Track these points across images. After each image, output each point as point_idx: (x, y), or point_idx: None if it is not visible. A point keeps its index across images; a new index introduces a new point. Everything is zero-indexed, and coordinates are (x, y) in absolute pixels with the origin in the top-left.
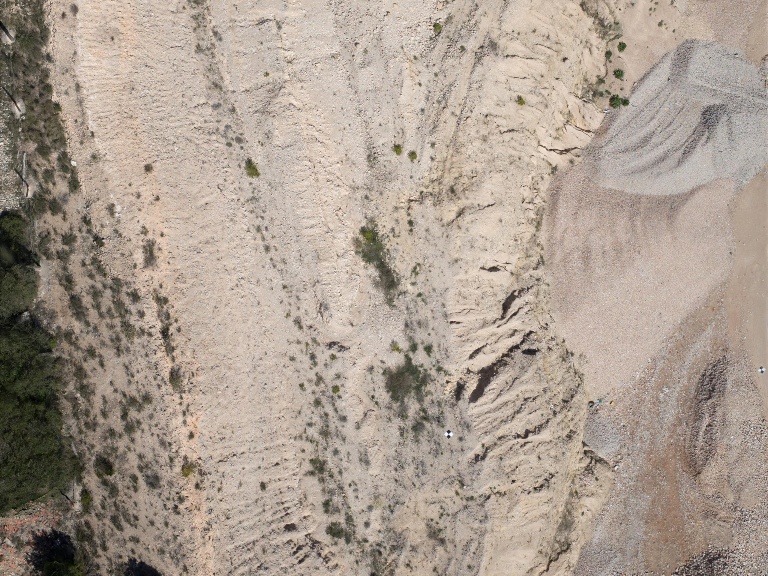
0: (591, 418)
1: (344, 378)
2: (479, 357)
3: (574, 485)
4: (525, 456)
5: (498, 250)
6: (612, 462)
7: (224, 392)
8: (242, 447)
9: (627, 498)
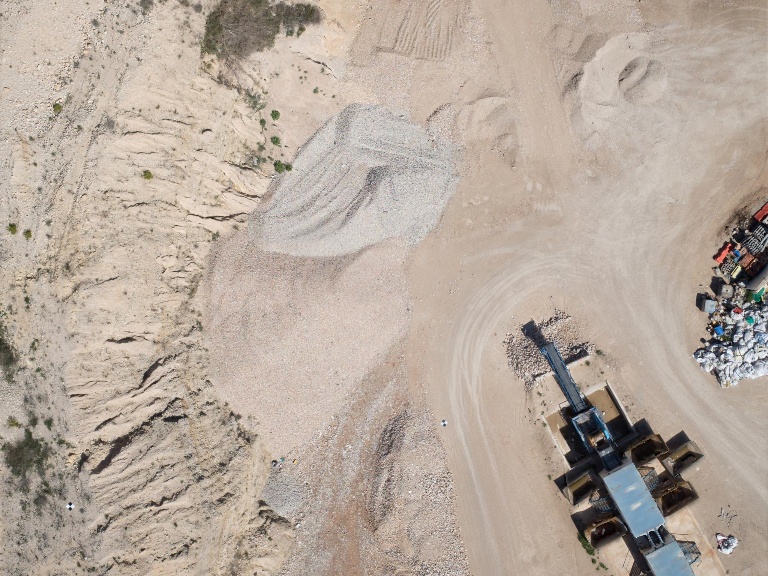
0: (273, 477)
1: None
2: (107, 428)
3: (243, 546)
4: (158, 524)
5: (129, 321)
6: (294, 520)
7: None
8: None
9: (309, 556)
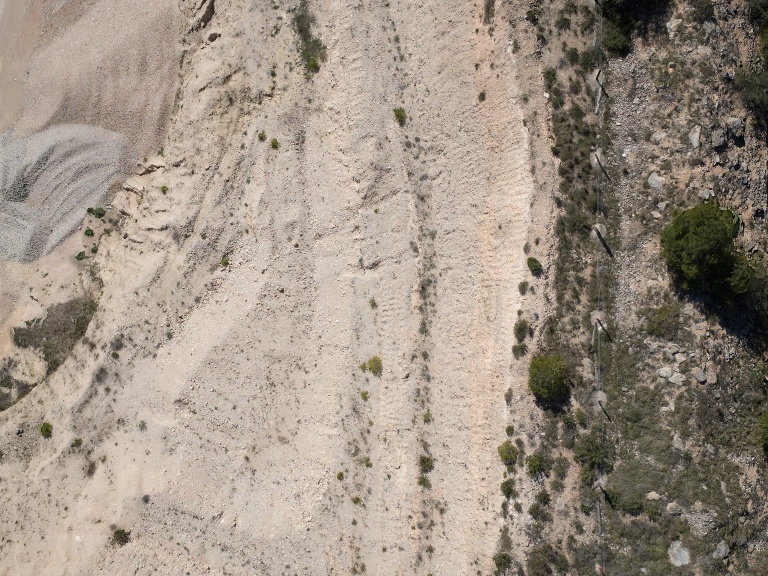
0: None
1: None
2: None
3: None
4: None
5: None
6: None
7: None
8: None
9: None
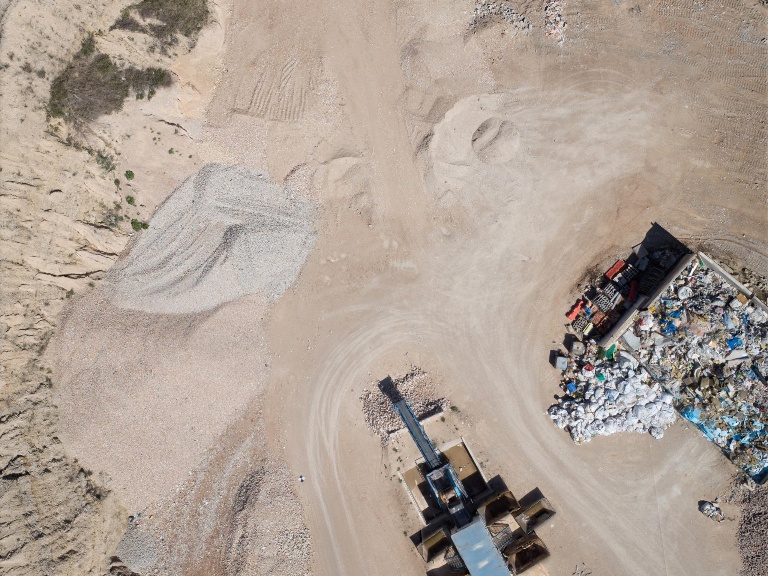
0: (129, 533)
1: None
2: None
3: None
4: None
5: None
6: None
7: None
8: None
9: None
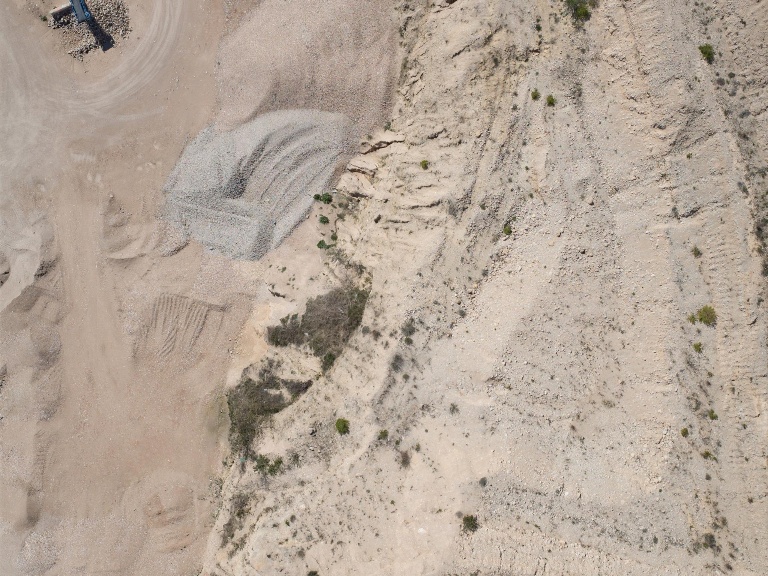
0: None
1: None
2: None
3: None
4: None
5: None
6: None
7: None
8: None
9: None
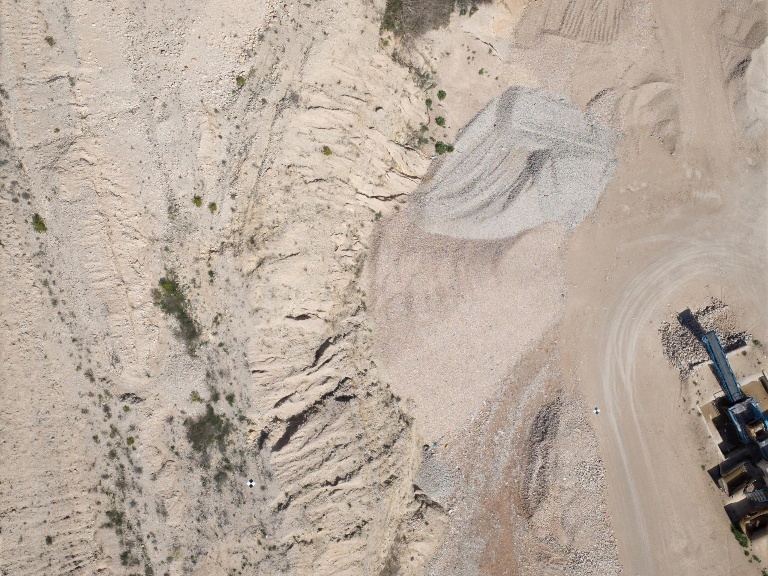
0: (426, 462)
1: (138, 430)
2: (285, 405)
3: (401, 530)
4: (334, 504)
5: (306, 298)
6: (446, 506)
7: (0, 447)
8: (23, 502)
9: (461, 542)
